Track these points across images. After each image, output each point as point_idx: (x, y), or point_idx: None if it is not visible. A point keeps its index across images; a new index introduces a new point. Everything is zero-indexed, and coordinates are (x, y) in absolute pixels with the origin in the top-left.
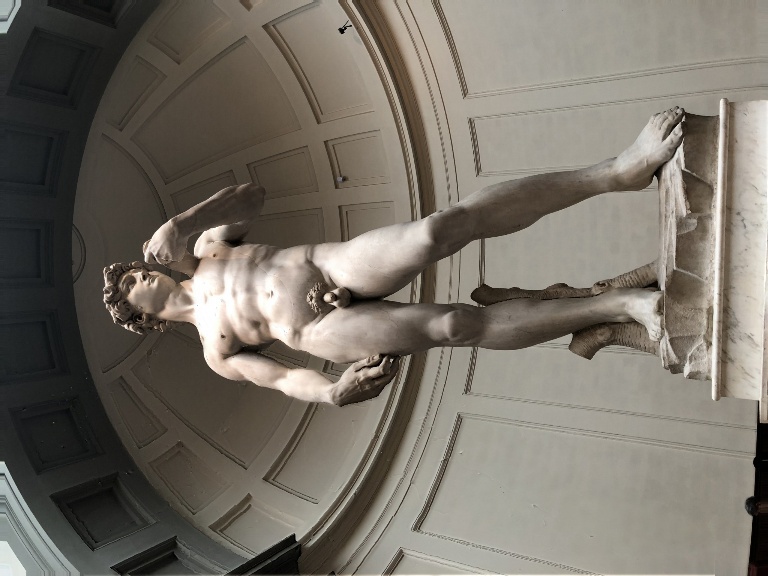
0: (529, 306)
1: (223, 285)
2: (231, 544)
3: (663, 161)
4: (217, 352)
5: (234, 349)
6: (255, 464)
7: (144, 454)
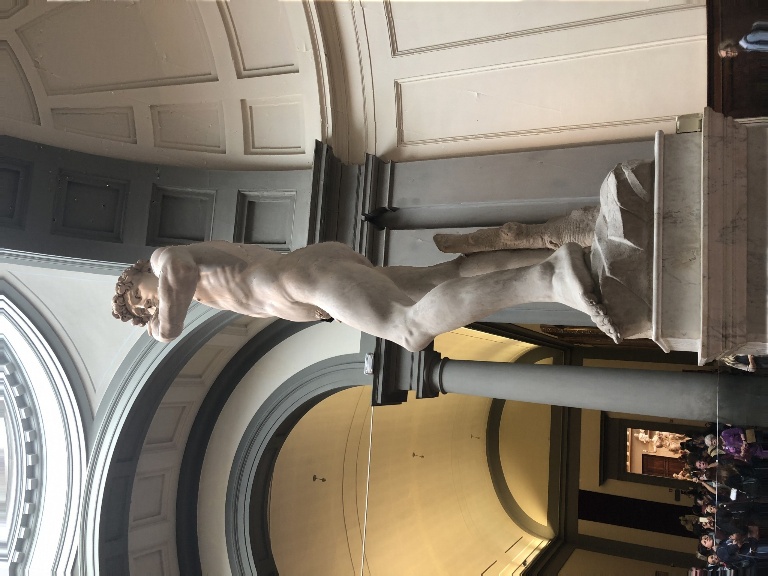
0: None
1: None
2: (272, 156)
3: None
4: None
5: None
6: (219, 68)
7: (144, 143)
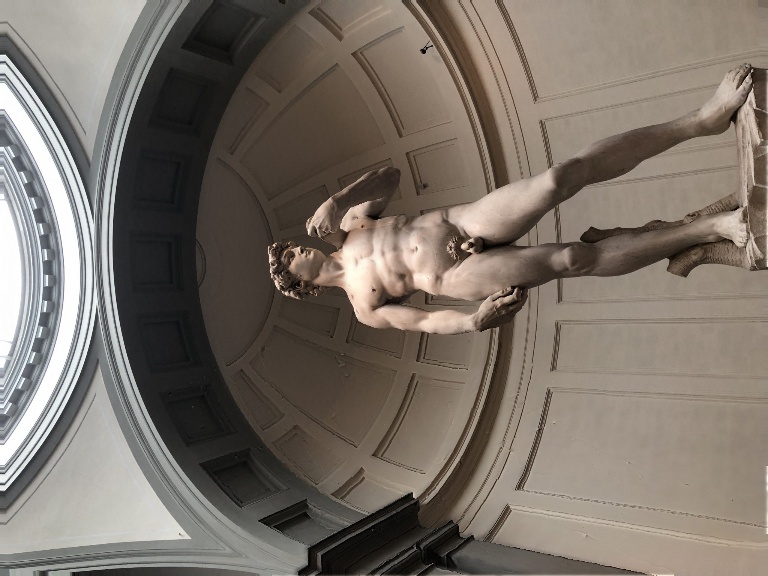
0: (633, 237)
1: (372, 248)
2: (353, 508)
3: (738, 106)
4: (367, 305)
5: (382, 301)
6: (364, 443)
7: (267, 435)
